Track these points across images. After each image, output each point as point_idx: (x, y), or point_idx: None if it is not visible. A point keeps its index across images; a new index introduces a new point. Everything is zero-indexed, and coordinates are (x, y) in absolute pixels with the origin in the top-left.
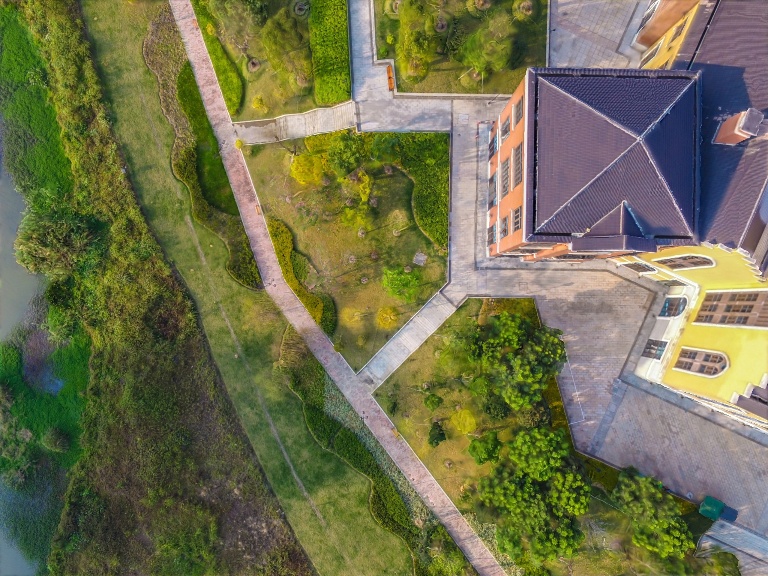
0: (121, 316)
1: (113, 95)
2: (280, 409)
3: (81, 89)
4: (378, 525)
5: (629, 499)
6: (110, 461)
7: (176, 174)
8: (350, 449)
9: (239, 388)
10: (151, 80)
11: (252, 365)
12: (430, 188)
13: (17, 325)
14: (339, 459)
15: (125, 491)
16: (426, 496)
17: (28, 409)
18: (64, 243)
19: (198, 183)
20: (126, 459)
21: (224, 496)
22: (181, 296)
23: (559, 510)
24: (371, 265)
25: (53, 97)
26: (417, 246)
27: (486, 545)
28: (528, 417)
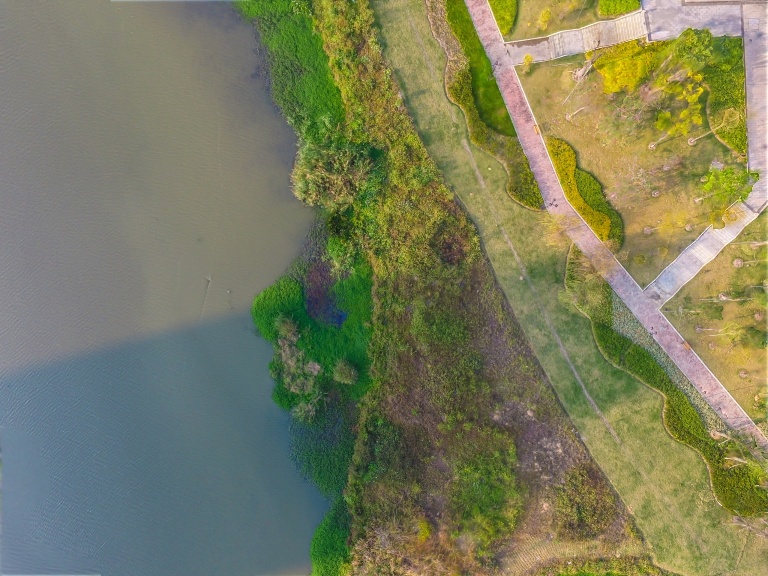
0: (406, 243)
1: (381, 20)
2: (568, 329)
3: (351, 15)
4: (673, 439)
5: None
6: (402, 389)
7: (451, 97)
8: (642, 365)
9: (526, 310)
10: (419, 3)
11: (538, 287)
12: (727, 94)
13: (296, 259)
14: (630, 376)
15: (419, 418)
16: (719, 408)
17: (314, 342)
18: (347, 171)
19: (475, 105)
20: (418, 387)
21: (518, 418)
22: (465, 220)
23: None
24: (663, 177)
25: (319, 25)
26: (713, 155)
27: None
28: None
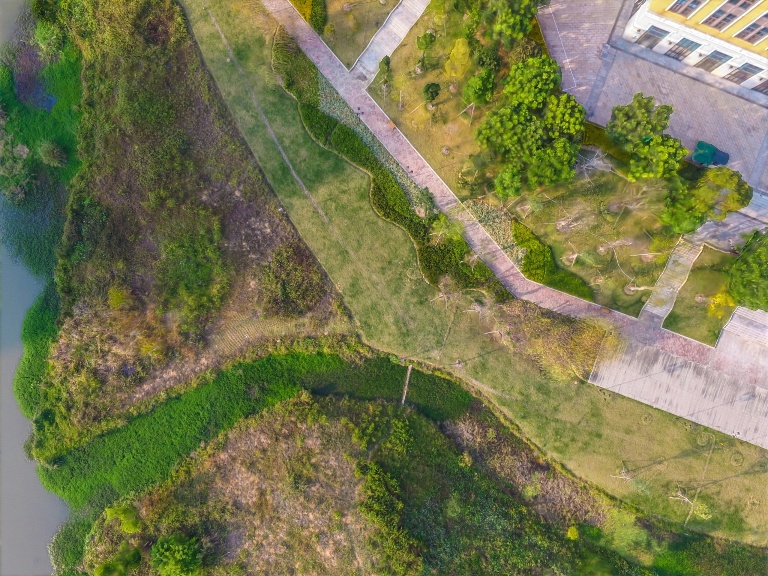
0: (110, 24)
1: None
2: (276, 110)
3: None
4: (380, 218)
5: (623, 120)
6: (109, 170)
7: None
8: (347, 144)
9: (233, 92)
10: None
11: (245, 68)
12: None
13: (6, 44)
14: (337, 156)
15: (126, 199)
16: (425, 187)
17: (23, 125)
18: None
19: None
20: (125, 167)
21: (225, 198)
22: (169, 1)
23: (555, 130)
24: None
25: None
26: None
27: (487, 230)
28: (520, 49)
